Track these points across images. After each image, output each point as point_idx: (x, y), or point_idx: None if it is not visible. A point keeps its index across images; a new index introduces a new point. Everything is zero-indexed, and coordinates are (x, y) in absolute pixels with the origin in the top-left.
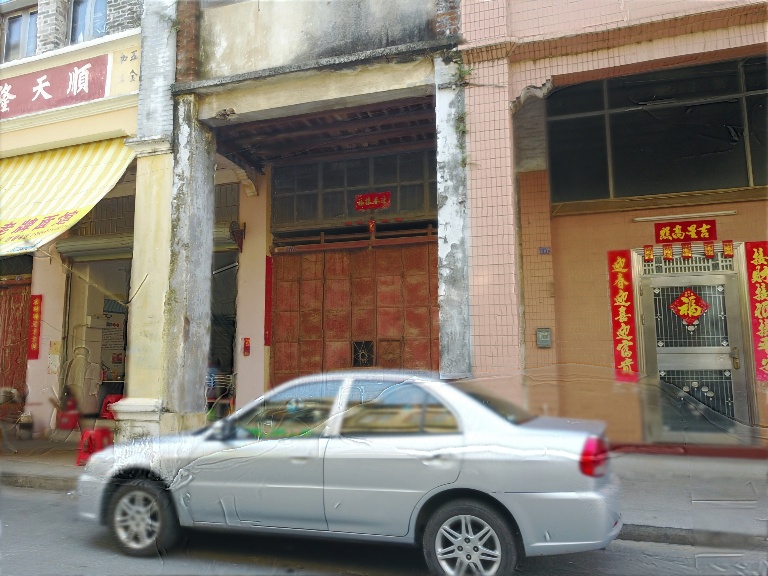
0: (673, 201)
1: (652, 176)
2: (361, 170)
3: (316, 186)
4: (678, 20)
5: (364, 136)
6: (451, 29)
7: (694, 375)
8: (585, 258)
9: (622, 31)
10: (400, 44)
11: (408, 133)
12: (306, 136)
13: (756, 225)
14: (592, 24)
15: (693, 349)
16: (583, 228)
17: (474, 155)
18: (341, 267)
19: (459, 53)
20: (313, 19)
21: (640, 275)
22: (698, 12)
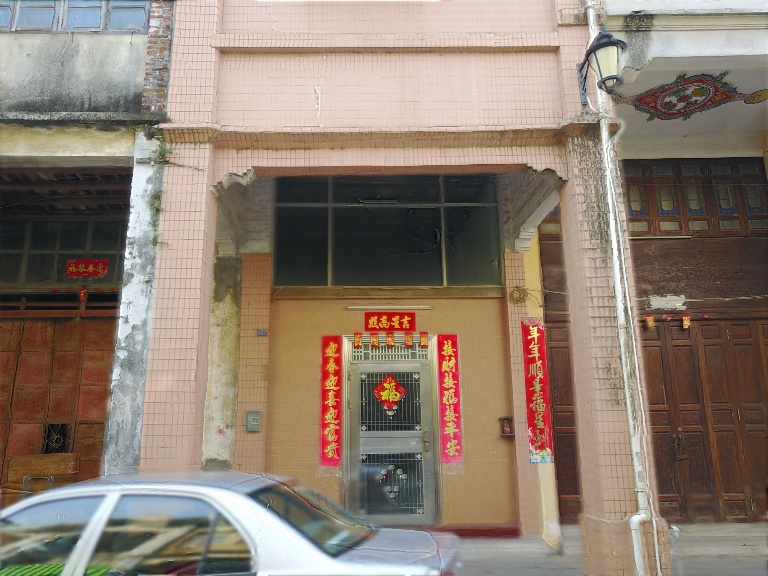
0: (381, 293)
1: (365, 268)
2: (78, 233)
3: (22, 246)
4: (363, 135)
5: (77, 198)
6: (156, 106)
7: (391, 458)
8: (301, 342)
9: (316, 136)
10: (103, 111)
11: (128, 201)
12: (7, 190)
13: (447, 320)
14: (291, 125)
15: (391, 433)
16: (301, 312)
17: (166, 234)
18: (43, 338)
19: (160, 131)
20: (7, 68)
21: (350, 361)
22: (378, 131)
